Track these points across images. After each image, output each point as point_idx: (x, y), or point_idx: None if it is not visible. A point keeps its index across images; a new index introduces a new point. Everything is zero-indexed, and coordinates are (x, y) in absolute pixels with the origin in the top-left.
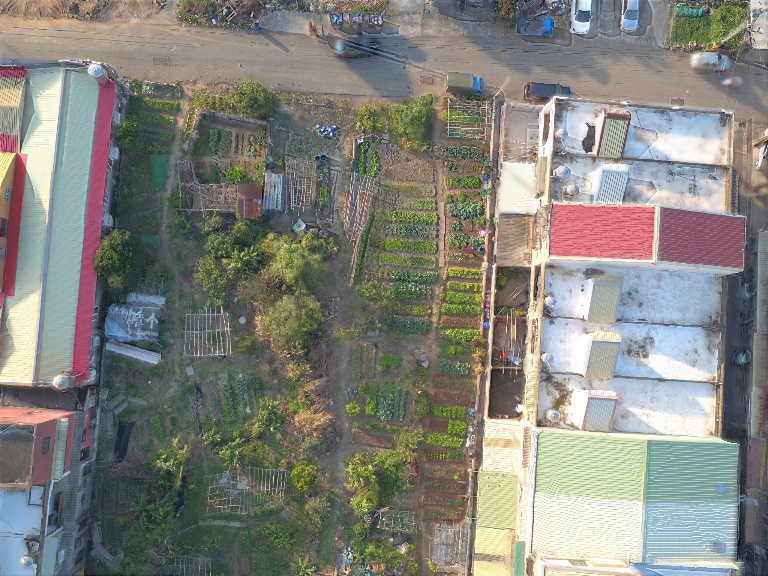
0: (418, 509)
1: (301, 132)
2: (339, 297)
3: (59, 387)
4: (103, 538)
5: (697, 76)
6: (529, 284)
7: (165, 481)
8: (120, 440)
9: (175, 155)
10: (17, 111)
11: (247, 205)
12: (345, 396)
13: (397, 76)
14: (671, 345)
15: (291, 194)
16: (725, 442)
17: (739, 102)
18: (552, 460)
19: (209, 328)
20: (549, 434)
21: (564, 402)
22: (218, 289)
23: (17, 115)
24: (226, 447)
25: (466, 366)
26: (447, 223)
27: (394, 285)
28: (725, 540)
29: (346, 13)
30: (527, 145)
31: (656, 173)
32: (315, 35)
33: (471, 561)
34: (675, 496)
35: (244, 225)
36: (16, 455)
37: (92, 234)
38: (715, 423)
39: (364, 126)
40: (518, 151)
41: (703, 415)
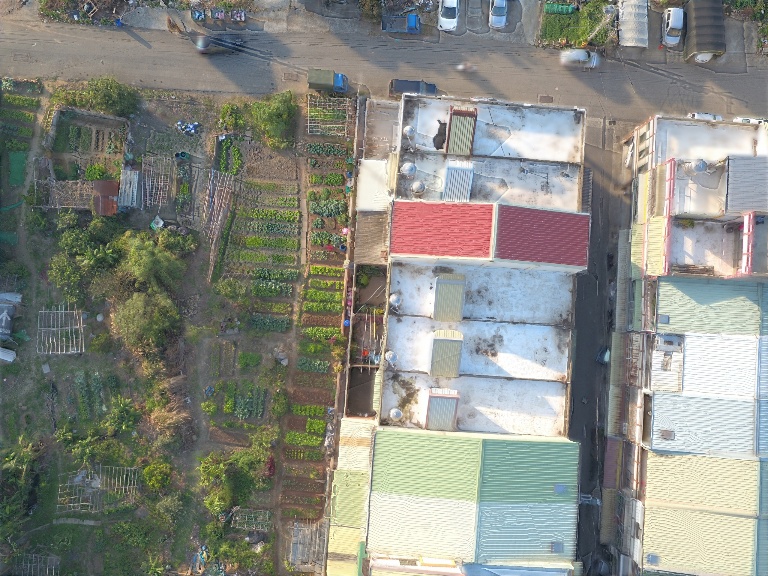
0: (275, 508)
1: (163, 129)
2: (198, 295)
3: None
4: None
5: (567, 73)
6: None
7: (16, 479)
8: None
9: (34, 152)
10: None
11: (103, 202)
12: (203, 394)
13: (261, 73)
14: (520, 343)
15: (148, 191)
16: (566, 441)
17: (609, 99)
18: (386, 459)
19: (62, 325)
20: (386, 433)
21: (410, 400)
22: (72, 286)
23: None
24: (77, 445)
25: (326, 364)
26: (309, 220)
27: (254, 283)
28: (562, 540)
29: None
30: (393, 142)
31: (508, 170)
32: (178, 31)
33: None
34: (511, 495)
35: (100, 222)
36: None
37: None
38: (564, 422)
39: (226, 123)
40: (384, 148)
41: (552, 414)
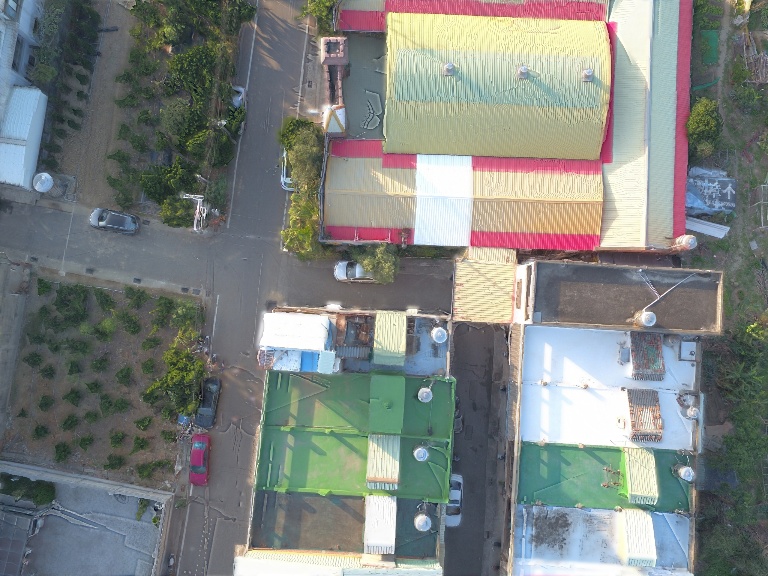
0: None
1: None
2: None
3: (690, 247)
4: None
5: None
6: None
7: (747, 352)
8: None
9: (727, 30)
10: None
11: None
12: None
13: None
14: None
15: None
16: None
17: None
18: None
19: None
20: None
21: None
22: None
23: None
24: None
25: None
26: None
27: None
28: None
29: None
30: None
31: None
32: None
33: None
34: None
35: None
36: (698, 303)
37: (684, 101)
38: None
39: None
40: None
41: None
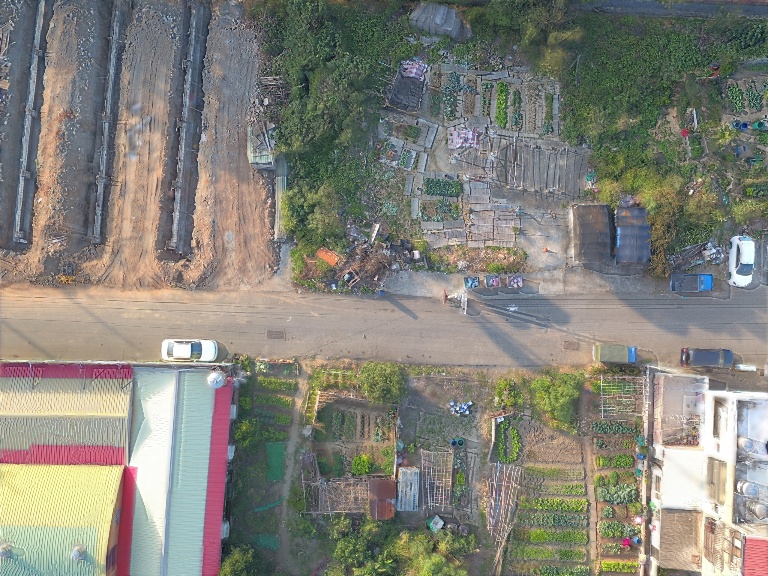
0: None
1: (433, 410)
2: None
3: None
4: None
5: None
6: None
7: None
8: None
9: (294, 441)
10: (126, 421)
11: (380, 506)
12: None
13: (538, 342)
14: None
15: (428, 491)
16: None
17: None
18: None
19: None
20: None
21: None
22: None
23: (126, 425)
24: None
25: None
26: (598, 509)
27: None
28: None
29: (480, 271)
30: (684, 414)
31: None
32: None
33: None
34: None
35: (376, 527)
36: None
37: (212, 557)
38: None
39: (504, 403)
40: (674, 421)
41: None
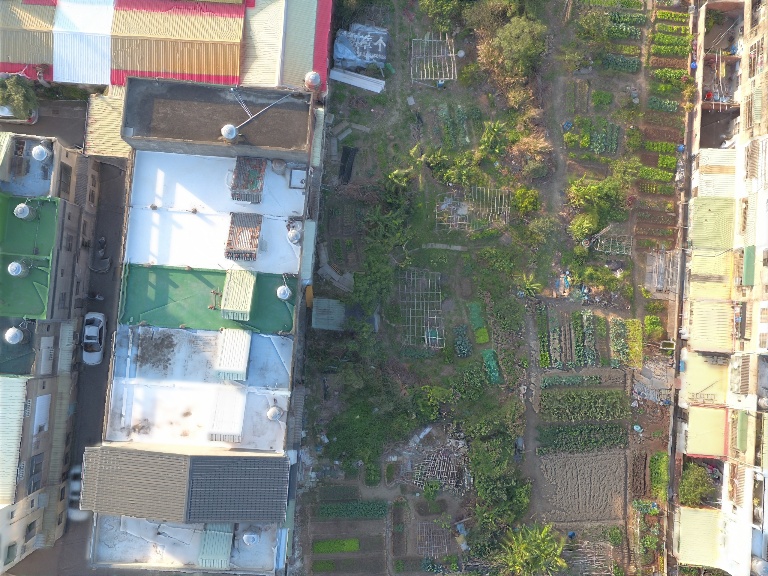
0: None
1: None
2: (553, 35)
3: (311, 82)
4: (329, 258)
5: None
6: (742, 18)
7: (393, 200)
8: (345, 164)
9: None
10: None
11: None
12: (560, 129)
13: None
14: None
15: None
16: None
17: None
18: None
19: (435, 53)
20: None
21: None
22: (443, 16)
23: None
24: (453, 167)
25: (675, 103)
26: None
27: None
28: None
29: None
30: None
31: None
32: None
33: (682, 288)
34: None
35: None
36: (291, 124)
37: None
38: None
39: None
40: None
41: None
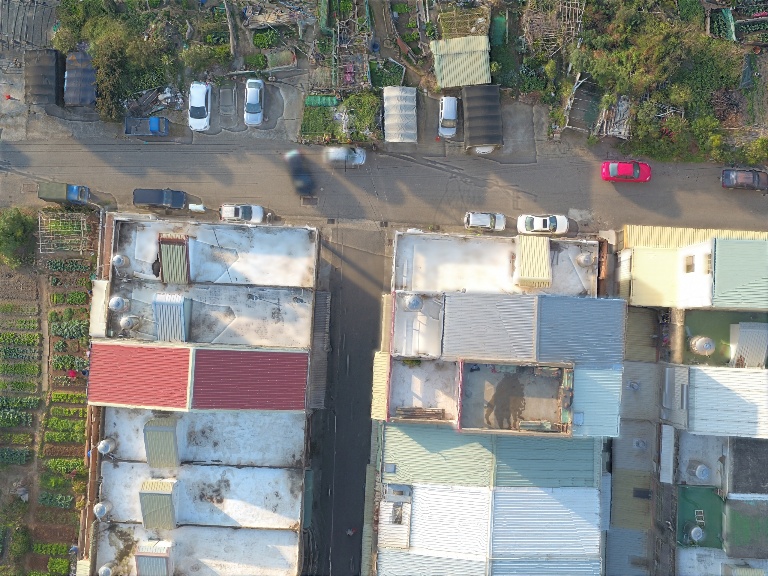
0: None
1: None
2: None
3: None
4: None
5: None
6: None
7: None
8: None
9: None
10: None
11: None
12: None
13: None
14: (249, 488)
15: None
16: None
17: (380, 199)
18: None
19: None
20: None
21: (128, 553)
22: None
23: None
24: None
25: (68, 499)
26: (51, 344)
27: None
28: None
29: None
30: None
31: (235, 297)
32: None
33: None
34: None
35: None
36: None
37: None
38: None
39: None
40: None
41: (283, 565)
